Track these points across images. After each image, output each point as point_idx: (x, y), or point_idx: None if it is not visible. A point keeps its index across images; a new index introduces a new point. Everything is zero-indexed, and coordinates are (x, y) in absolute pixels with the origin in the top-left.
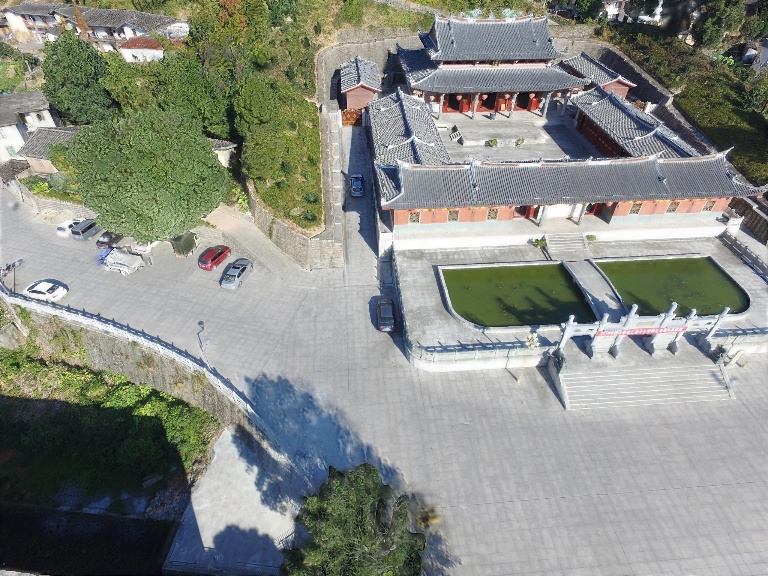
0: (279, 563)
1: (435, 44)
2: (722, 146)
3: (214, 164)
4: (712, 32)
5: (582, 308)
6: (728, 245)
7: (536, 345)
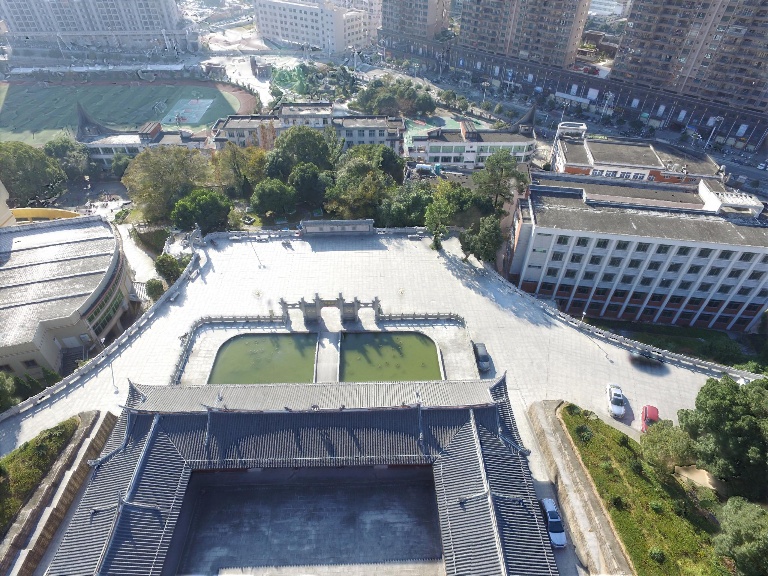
0: None
1: None
2: None
3: None
4: None
5: None
6: None
7: None
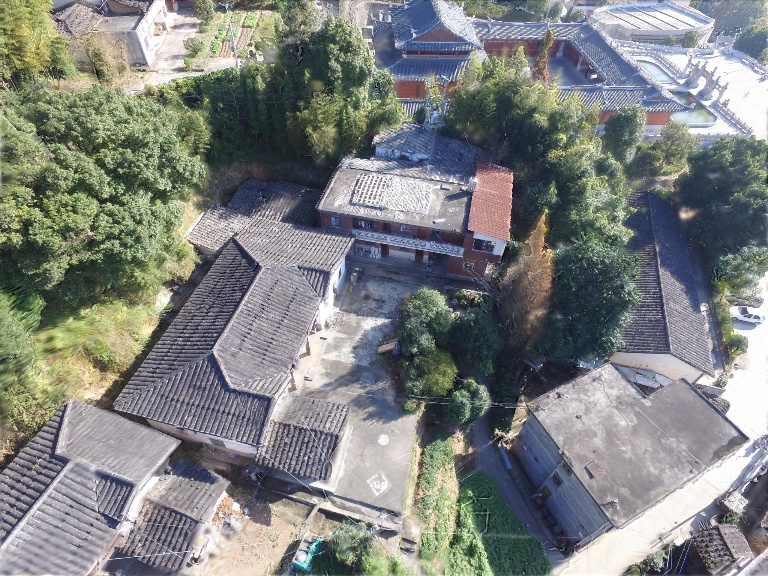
0: None
1: (451, 41)
2: None
3: None
4: None
5: None
6: None
7: None
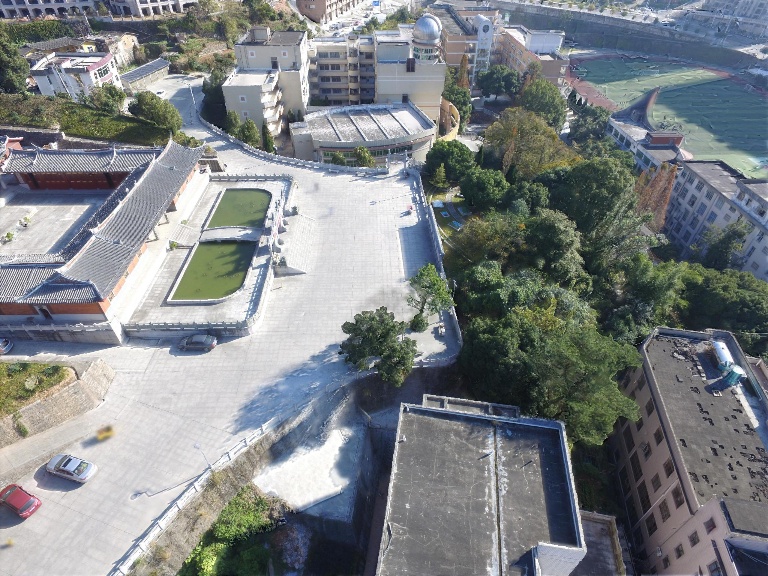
0: (356, 441)
1: None
2: (138, 141)
3: None
4: (17, 78)
5: (241, 246)
6: (219, 181)
7: None
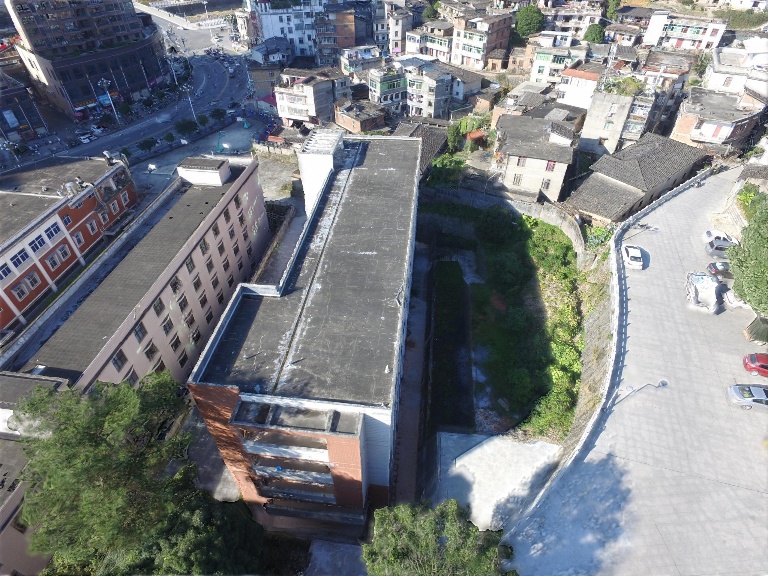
0: None
1: None
2: None
3: None
4: None
5: None
6: None
7: None
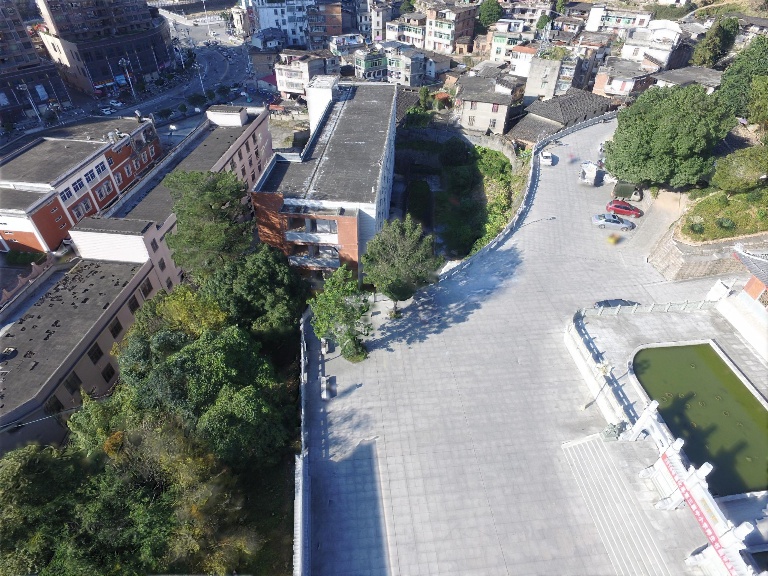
0: None
1: None
2: None
3: (695, 149)
4: None
5: None
6: None
7: (600, 373)
